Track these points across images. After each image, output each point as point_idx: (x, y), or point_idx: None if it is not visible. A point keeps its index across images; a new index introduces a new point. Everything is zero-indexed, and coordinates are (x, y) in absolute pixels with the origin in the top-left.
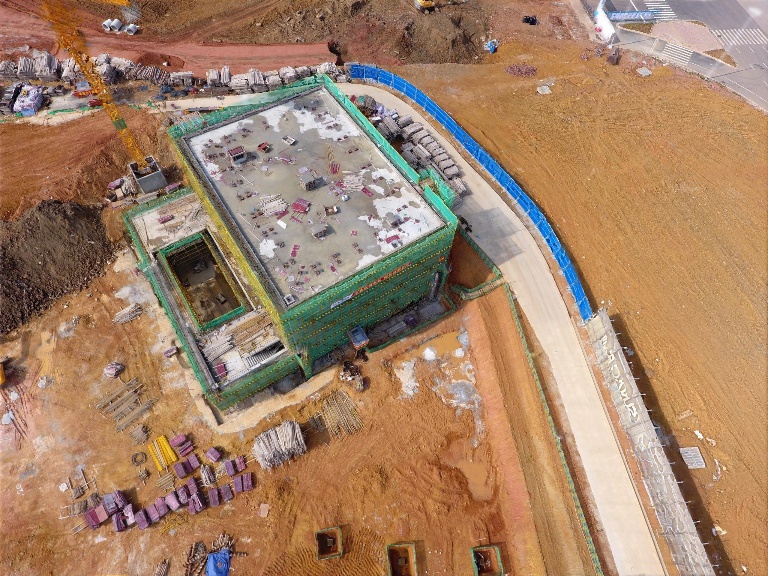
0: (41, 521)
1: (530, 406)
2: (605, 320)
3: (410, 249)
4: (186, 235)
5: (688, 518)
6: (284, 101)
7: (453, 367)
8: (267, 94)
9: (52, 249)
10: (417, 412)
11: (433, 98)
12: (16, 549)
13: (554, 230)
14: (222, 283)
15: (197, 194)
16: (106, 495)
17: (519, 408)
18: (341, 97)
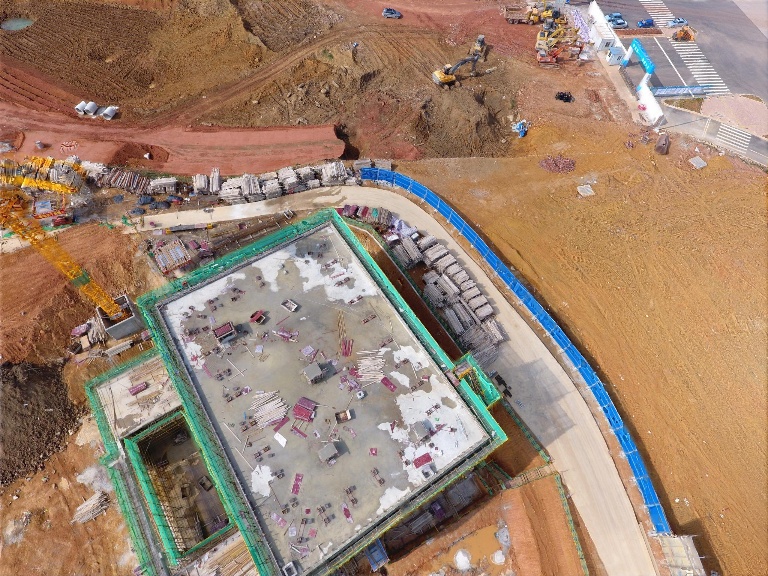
0: None
1: None
2: (691, 553)
3: (446, 477)
4: (163, 412)
5: None
6: (284, 245)
7: None
8: (264, 203)
9: None
10: None
11: (458, 205)
12: None
13: (611, 392)
14: None
15: None
16: None
17: None
18: (351, 209)
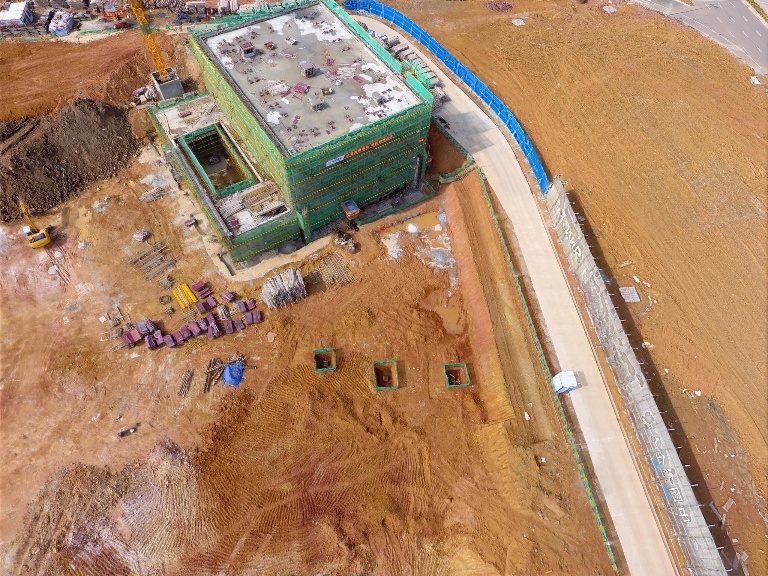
0: (85, 342)
1: (495, 259)
2: (558, 185)
3: (393, 120)
4: (202, 127)
5: (616, 319)
6: (287, 12)
7: (432, 238)
8: None
9: (86, 140)
10: (400, 270)
11: None
12: (66, 361)
13: None
14: (233, 173)
15: (211, 94)
16: (139, 322)
17: (486, 262)
18: None
